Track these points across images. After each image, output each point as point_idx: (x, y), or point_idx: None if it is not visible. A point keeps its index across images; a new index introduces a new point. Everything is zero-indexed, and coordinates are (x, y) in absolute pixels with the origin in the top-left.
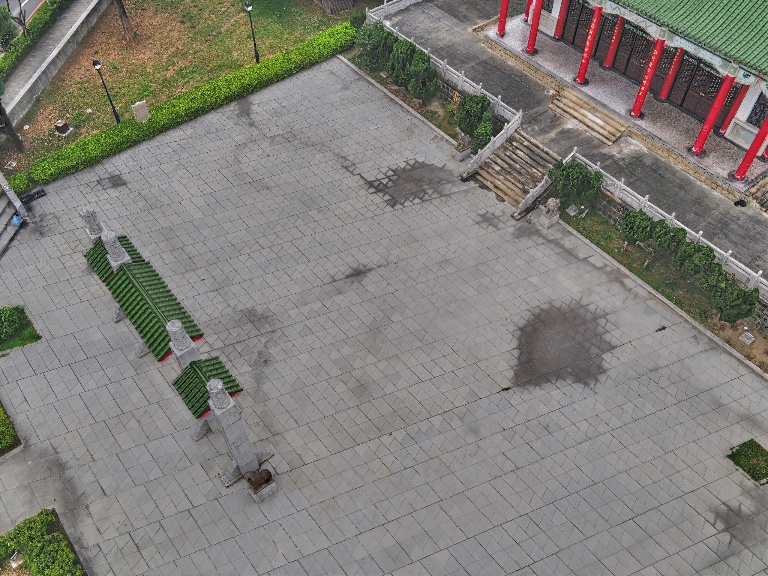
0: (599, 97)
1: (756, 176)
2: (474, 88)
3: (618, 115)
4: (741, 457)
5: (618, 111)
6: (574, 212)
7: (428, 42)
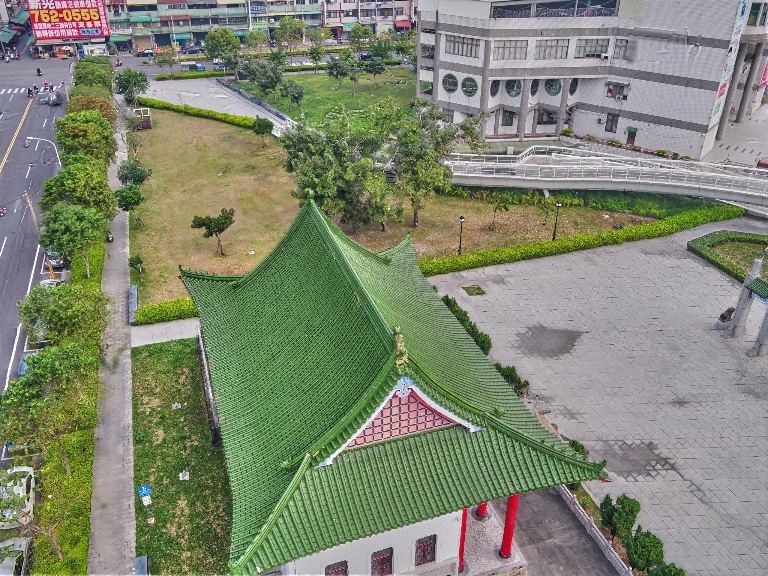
0: None
1: None
2: None
3: None
4: None
5: None
6: None
7: None
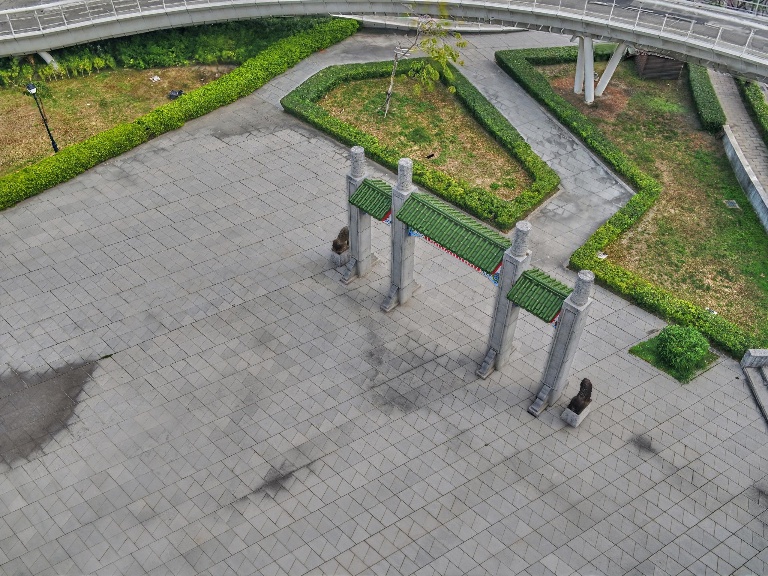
0: None
1: None
2: None
3: None
4: None
5: None
6: None
7: None
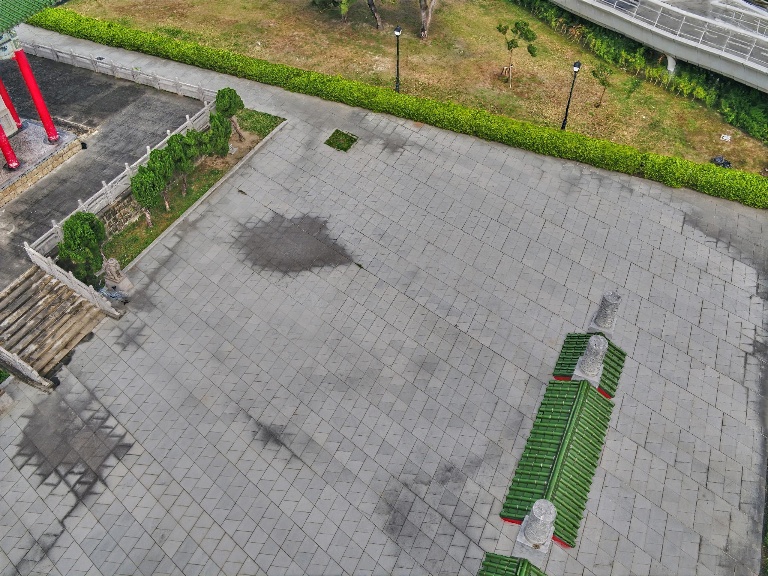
0: None
1: None
2: None
3: None
4: (342, 146)
5: None
6: None
7: None
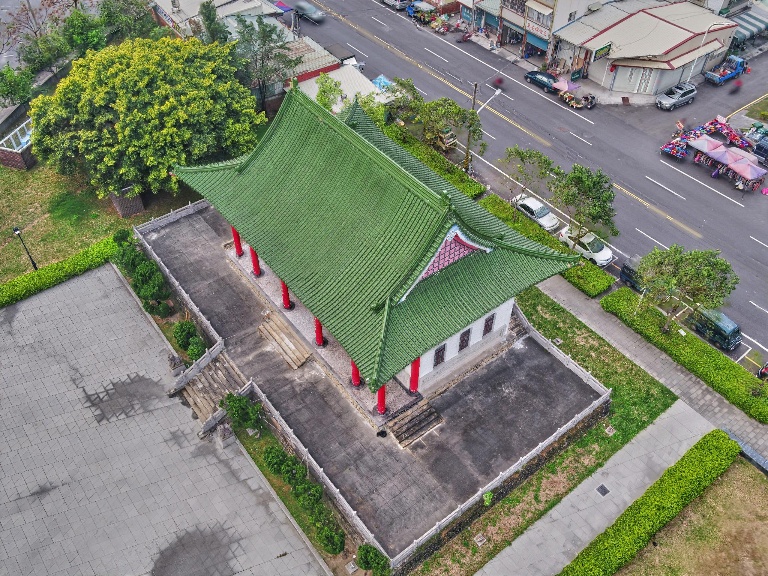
0: (297, 323)
1: (397, 410)
2: (196, 310)
3: (305, 342)
4: None
5: (307, 338)
6: (252, 432)
7: (182, 257)
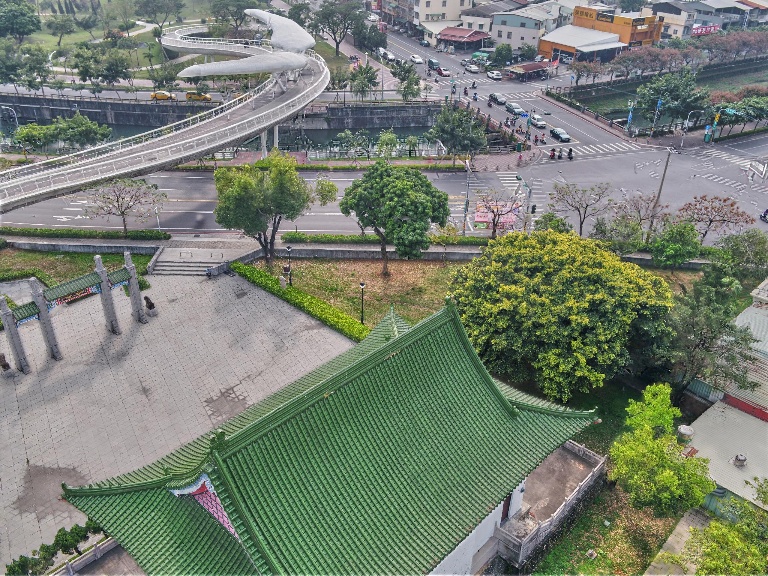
0: None
1: None
2: None
3: None
4: None
5: None
6: None
7: None
